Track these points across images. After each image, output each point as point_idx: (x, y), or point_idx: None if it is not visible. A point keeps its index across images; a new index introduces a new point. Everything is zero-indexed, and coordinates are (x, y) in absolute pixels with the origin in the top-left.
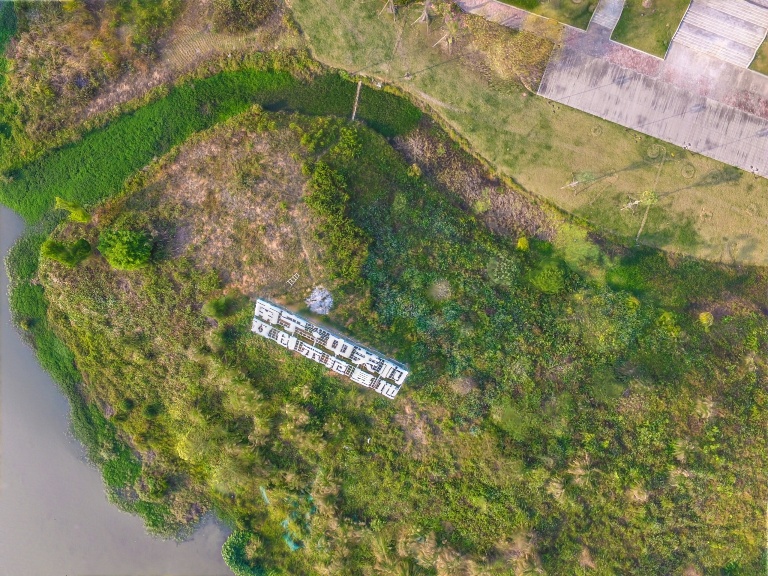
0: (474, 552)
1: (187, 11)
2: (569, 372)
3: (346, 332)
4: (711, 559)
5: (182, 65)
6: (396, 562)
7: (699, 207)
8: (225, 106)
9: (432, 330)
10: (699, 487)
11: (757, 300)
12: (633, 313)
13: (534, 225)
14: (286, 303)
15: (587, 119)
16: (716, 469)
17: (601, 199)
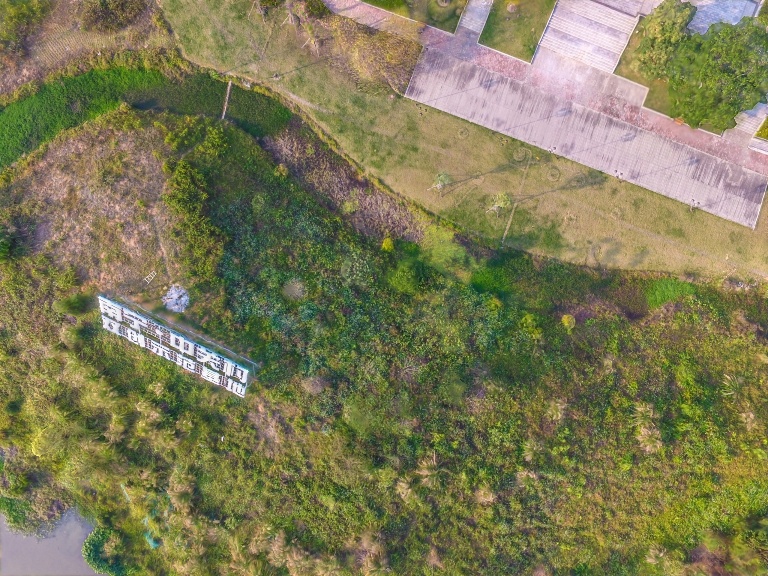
0: (325, 551)
1: (57, 9)
2: (424, 372)
3: (201, 330)
4: (560, 560)
5: (52, 63)
6: (250, 560)
7: (564, 210)
8: (95, 104)
9: (287, 329)
10: (548, 488)
11: (621, 303)
12: (495, 315)
13: (401, 226)
14: (142, 301)
15: (454, 122)
16: (567, 470)
17: (467, 201)
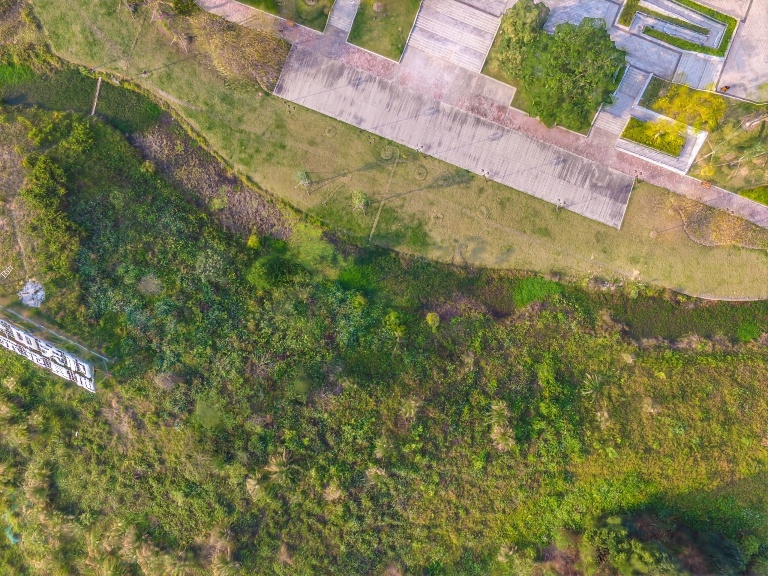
0: (176, 547)
1: None
2: (281, 369)
3: (56, 325)
4: (413, 558)
5: None
6: (105, 556)
7: (430, 209)
8: None
9: (143, 325)
10: (400, 485)
11: (488, 302)
12: (358, 312)
13: (269, 223)
14: None
15: (322, 120)
16: (420, 468)
17: (334, 199)
